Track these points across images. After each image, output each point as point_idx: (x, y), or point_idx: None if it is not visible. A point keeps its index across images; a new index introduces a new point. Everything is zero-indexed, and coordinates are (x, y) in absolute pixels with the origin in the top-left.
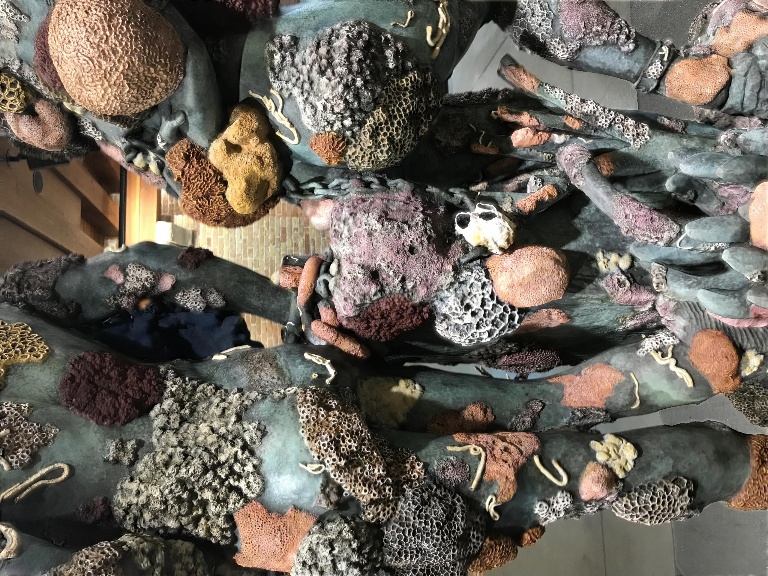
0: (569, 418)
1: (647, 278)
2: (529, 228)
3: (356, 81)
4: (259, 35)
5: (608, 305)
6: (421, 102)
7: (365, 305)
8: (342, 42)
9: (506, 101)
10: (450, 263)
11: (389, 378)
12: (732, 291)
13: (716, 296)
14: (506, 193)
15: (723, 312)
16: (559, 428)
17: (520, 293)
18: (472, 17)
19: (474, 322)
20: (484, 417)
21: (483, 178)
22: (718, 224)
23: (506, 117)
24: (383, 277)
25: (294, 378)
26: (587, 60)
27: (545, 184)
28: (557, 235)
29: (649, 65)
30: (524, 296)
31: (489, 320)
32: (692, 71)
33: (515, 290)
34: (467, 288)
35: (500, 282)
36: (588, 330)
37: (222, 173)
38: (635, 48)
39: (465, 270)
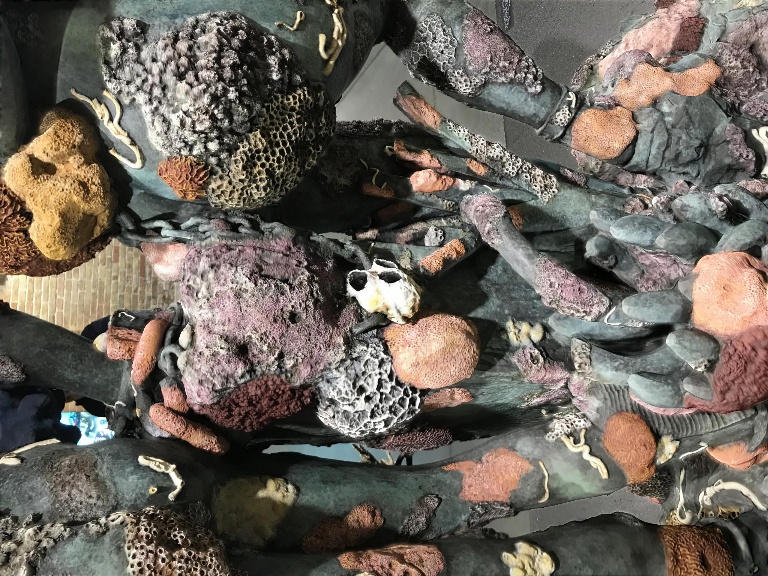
0: (468, 515)
1: (560, 352)
2: (431, 290)
3: (228, 91)
4: (90, 14)
5: (517, 383)
6: (310, 127)
7: (227, 390)
8: (210, 37)
9: (401, 136)
10: (340, 334)
11: (254, 478)
12: (663, 376)
13: (649, 383)
14: (404, 246)
15: (656, 402)
16: (462, 534)
17: (425, 373)
18: (368, 32)
19: (368, 409)
20: (372, 522)
21: (373, 224)
22: (659, 301)
23: (404, 155)
24: (254, 353)
25: (122, 495)
26: (490, 98)
27: (447, 237)
28: (463, 299)
29: (556, 111)
30: (429, 377)
31: (386, 406)
32: (600, 122)
33: (419, 369)
34: (361, 366)
35: (402, 359)
36: (489, 408)
37: (24, 201)
38: (542, 90)
39: (359, 344)
